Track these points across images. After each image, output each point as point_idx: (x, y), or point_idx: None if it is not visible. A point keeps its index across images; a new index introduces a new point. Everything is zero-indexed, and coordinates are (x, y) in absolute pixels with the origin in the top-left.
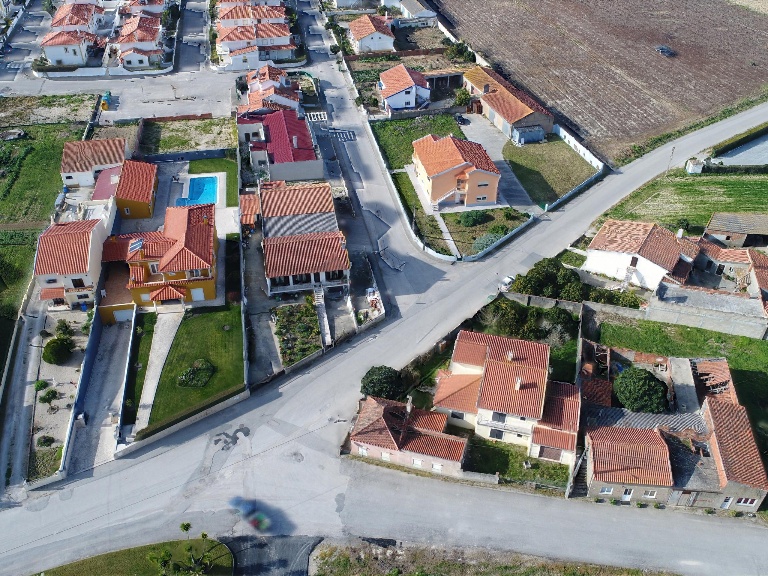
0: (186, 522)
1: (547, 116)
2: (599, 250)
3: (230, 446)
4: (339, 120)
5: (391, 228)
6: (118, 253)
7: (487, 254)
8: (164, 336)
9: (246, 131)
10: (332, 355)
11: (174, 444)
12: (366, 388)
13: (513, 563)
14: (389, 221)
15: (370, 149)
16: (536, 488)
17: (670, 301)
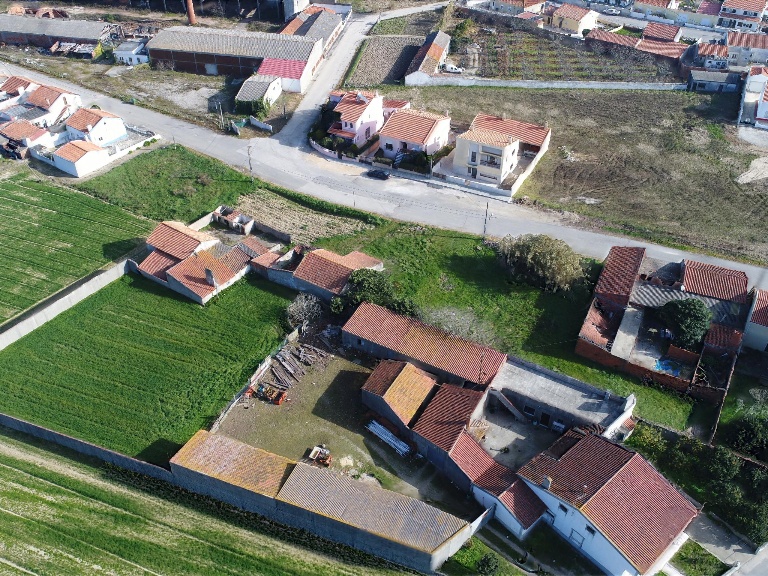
0: None
1: None
2: None
3: None
4: None
5: None
6: None
7: None
8: None
9: None
10: None
11: None
12: None
13: None
14: None
15: None
16: None
17: (604, 407)
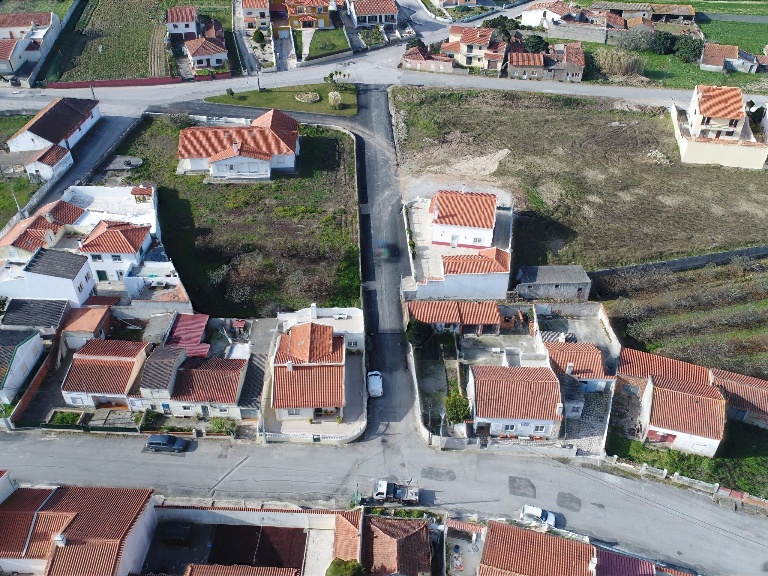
0: None
1: None
2: (527, 10)
3: None
4: None
5: (417, 12)
6: (277, 8)
7: (469, 21)
8: (308, 36)
9: None
10: (390, 46)
11: (322, 65)
12: (409, 46)
13: (473, 90)
14: (416, 10)
15: None
16: (486, 75)
17: None
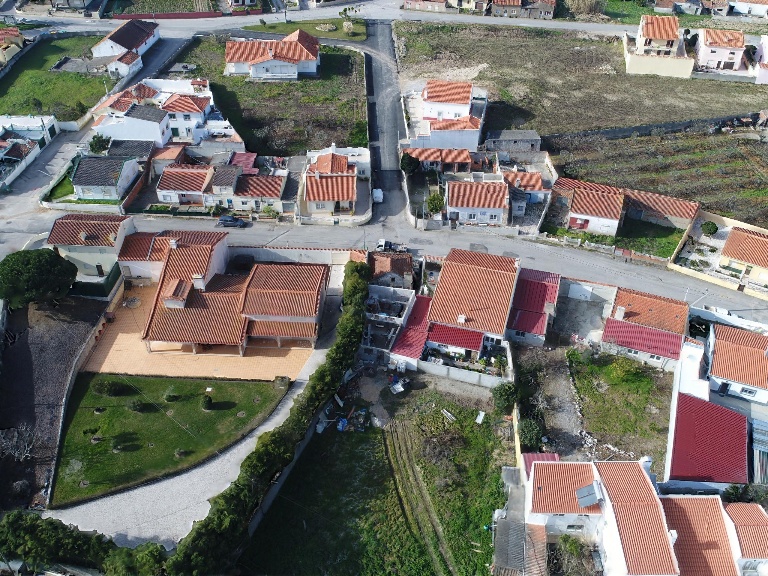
0: None
1: None
2: None
3: None
4: None
5: None
6: None
7: None
8: None
9: None
10: None
11: (337, 6)
12: None
13: (462, 24)
14: None
15: None
16: (473, 14)
17: None
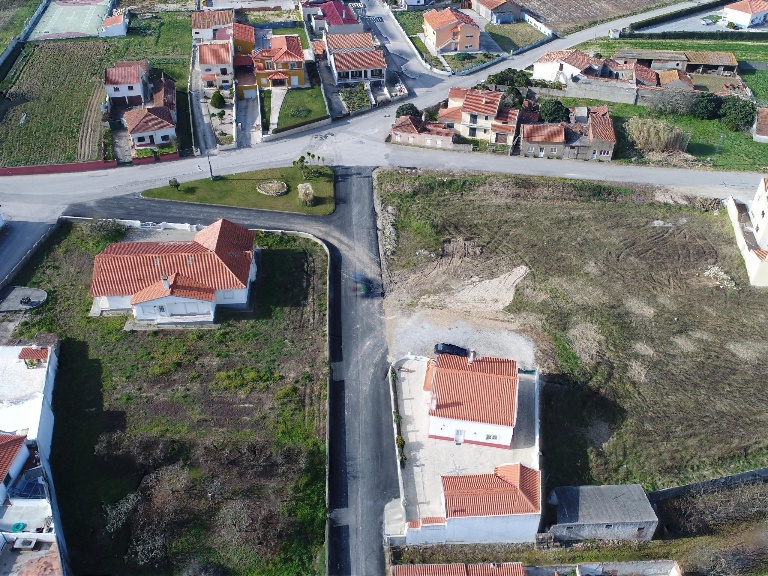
0: (306, 161)
1: (516, 5)
2: (540, 62)
3: (324, 139)
4: (371, 12)
5: (410, 61)
6: (243, 62)
7: (471, 73)
8: (278, 98)
9: (308, 13)
10: (377, 110)
11: (293, 138)
12: (399, 113)
13: (479, 174)
14: (408, 58)
15: (393, 26)
16: (493, 152)
17: None
